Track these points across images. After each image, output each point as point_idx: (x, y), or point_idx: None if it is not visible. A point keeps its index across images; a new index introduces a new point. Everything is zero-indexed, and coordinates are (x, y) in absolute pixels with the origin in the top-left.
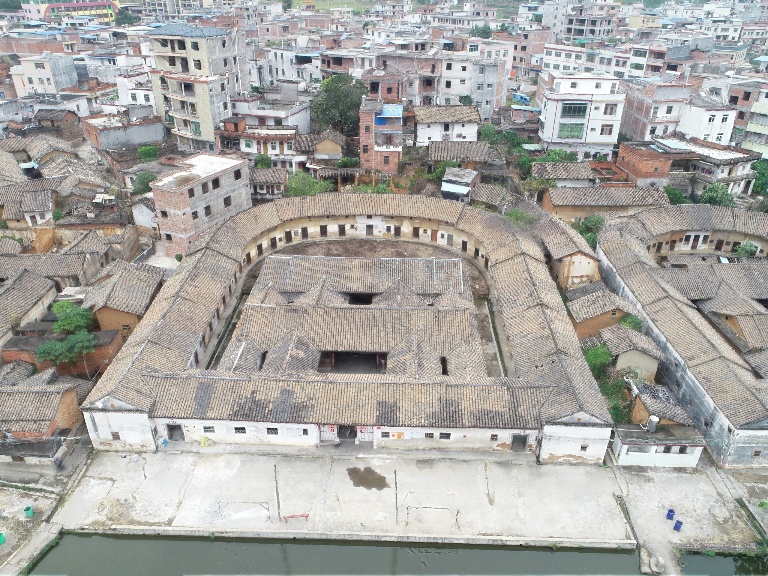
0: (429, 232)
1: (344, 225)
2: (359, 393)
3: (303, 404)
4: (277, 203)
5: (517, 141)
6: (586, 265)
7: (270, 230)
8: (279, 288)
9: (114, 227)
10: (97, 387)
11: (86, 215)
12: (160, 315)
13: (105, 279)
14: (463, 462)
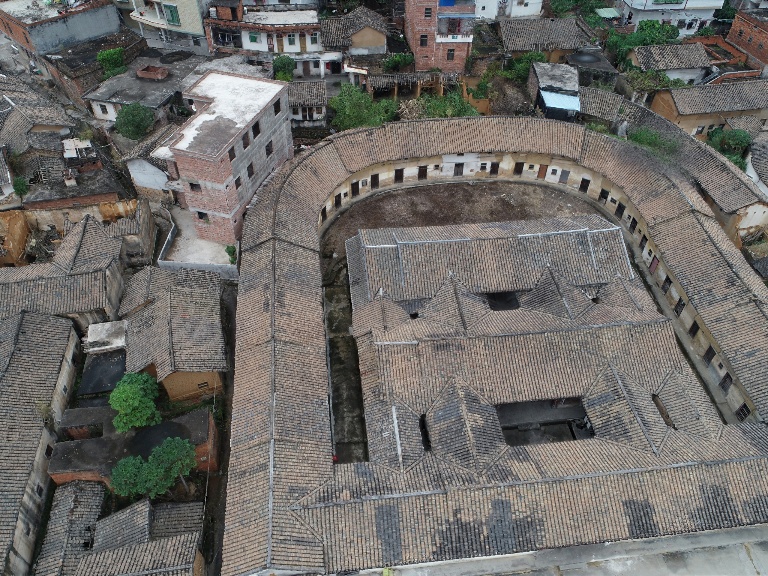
0: (536, 168)
1: (426, 166)
2: (596, 493)
3: (527, 520)
4: (338, 145)
5: (590, 5)
6: (760, 215)
7: None
8: (394, 296)
9: (110, 198)
10: (231, 537)
11: (62, 181)
12: (266, 383)
13: (144, 306)
14: (719, 550)
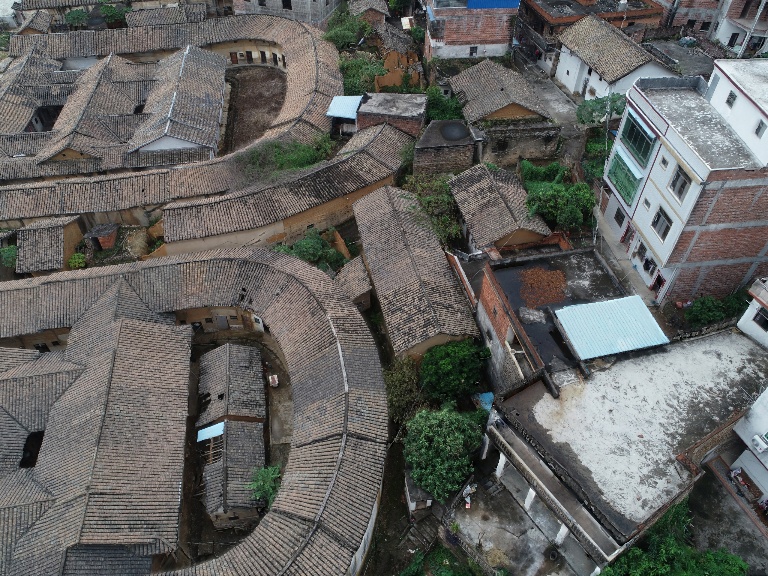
0: None
1: None
2: None
3: None
4: (290, 24)
5: None
6: None
7: (271, 44)
8: None
9: None
10: None
11: None
12: None
13: None
14: None
